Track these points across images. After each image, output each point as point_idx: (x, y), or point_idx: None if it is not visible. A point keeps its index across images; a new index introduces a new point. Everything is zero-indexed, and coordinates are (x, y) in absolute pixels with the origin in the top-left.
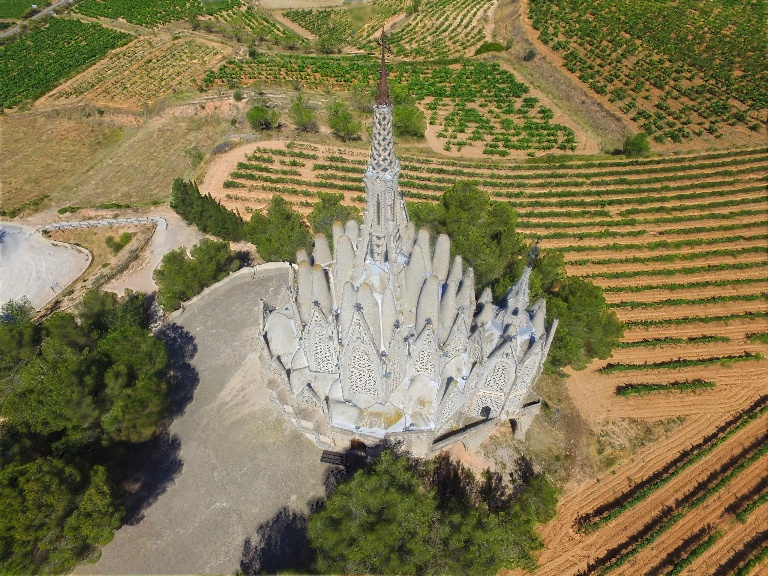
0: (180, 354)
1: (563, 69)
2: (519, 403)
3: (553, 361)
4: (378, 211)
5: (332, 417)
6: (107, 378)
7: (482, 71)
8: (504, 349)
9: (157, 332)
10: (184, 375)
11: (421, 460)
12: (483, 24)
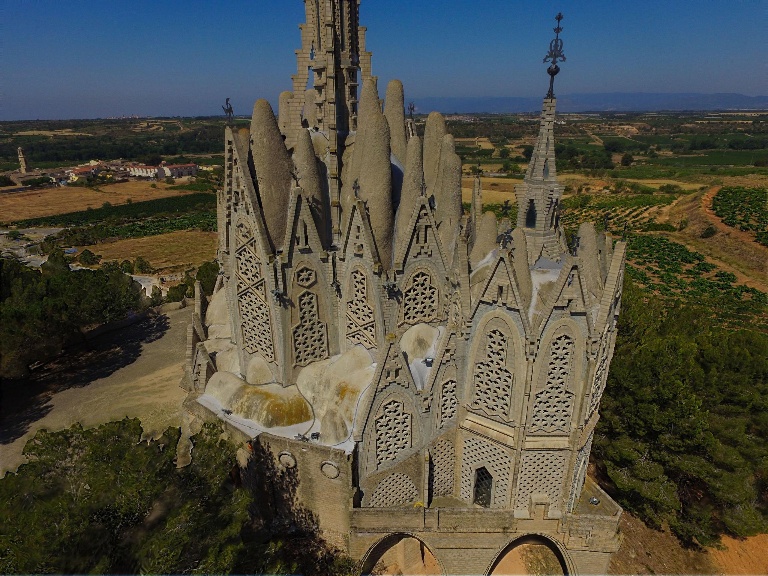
0: (143, 336)
1: (754, 244)
2: (559, 489)
3: (686, 508)
4: (318, 21)
5: (205, 389)
6: (15, 284)
7: (645, 241)
8: (496, 278)
9: (141, 314)
10: (126, 353)
11: (336, 552)
12: (655, 216)
